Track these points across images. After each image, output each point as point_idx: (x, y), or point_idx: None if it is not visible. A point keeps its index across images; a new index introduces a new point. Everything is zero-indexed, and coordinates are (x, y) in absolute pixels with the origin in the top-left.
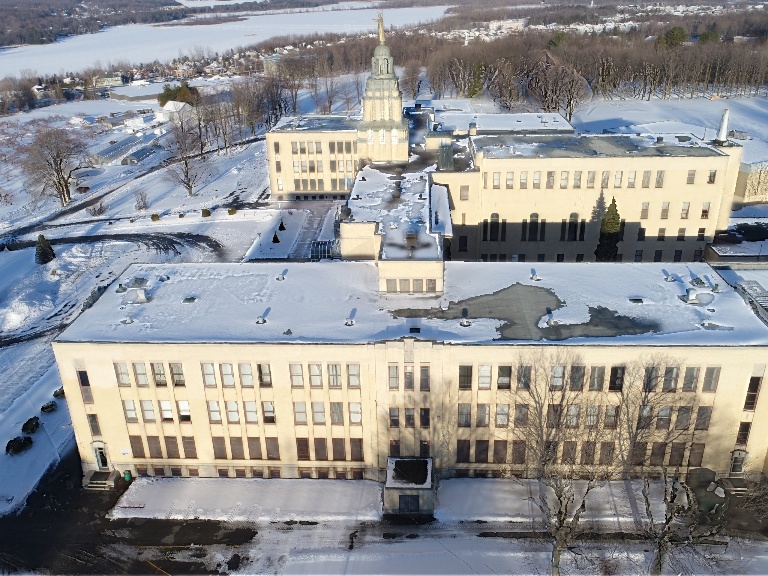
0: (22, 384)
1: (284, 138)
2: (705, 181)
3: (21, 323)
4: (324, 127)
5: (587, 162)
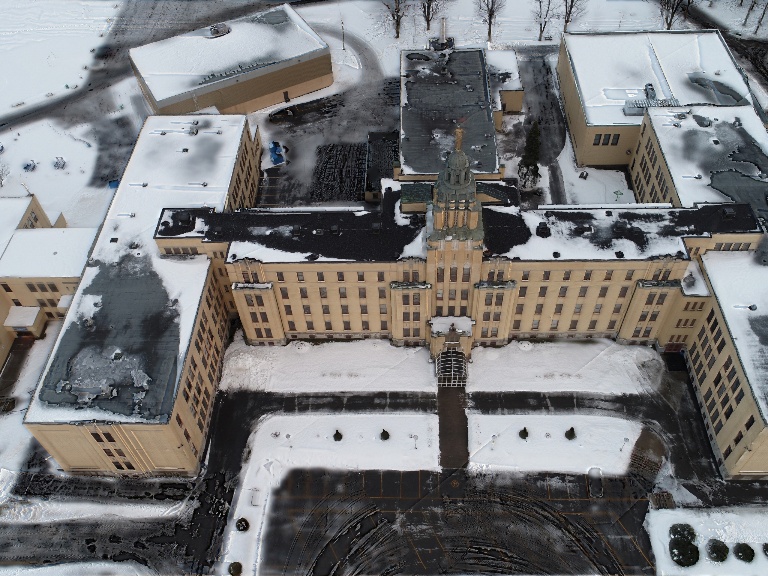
0: None
1: (179, 402)
2: None
3: None
4: (142, 349)
5: None
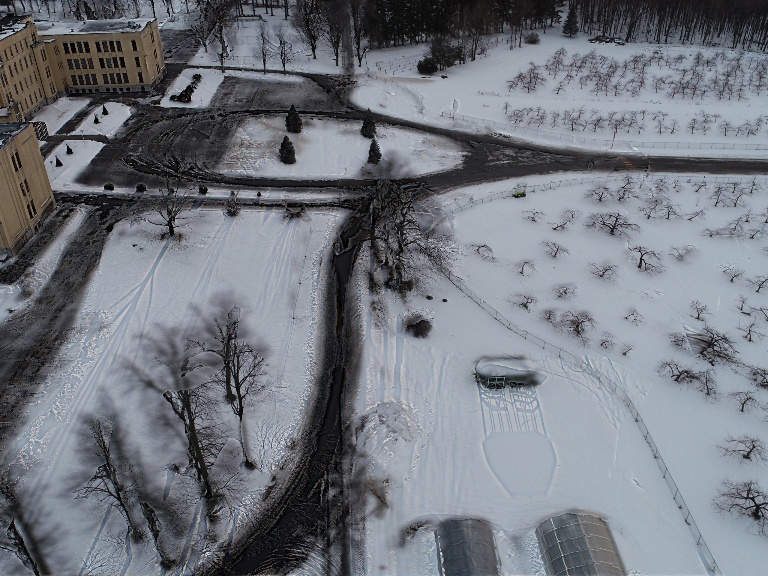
0: (220, 96)
1: None
2: None
3: None
4: None
5: None
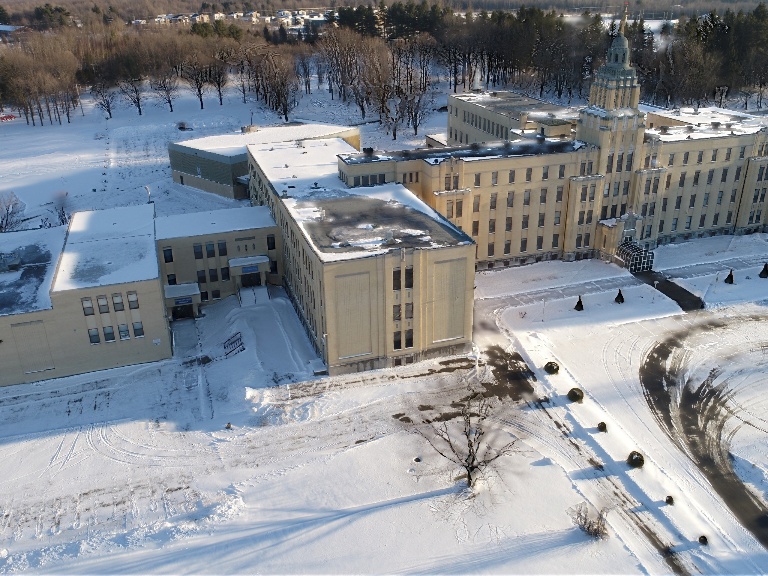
0: None
1: None
2: None
3: None
4: (395, 221)
5: None
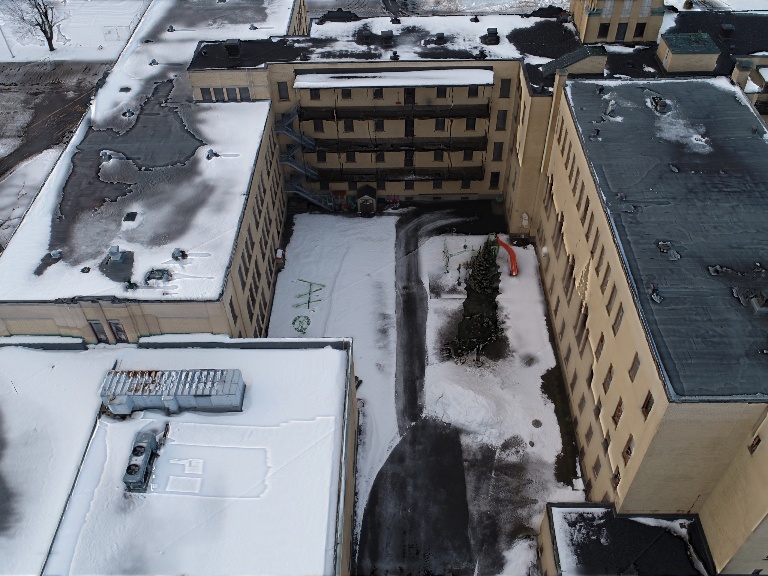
0: None
1: None
2: (641, 399)
3: (427, 7)
4: None
5: (594, 192)
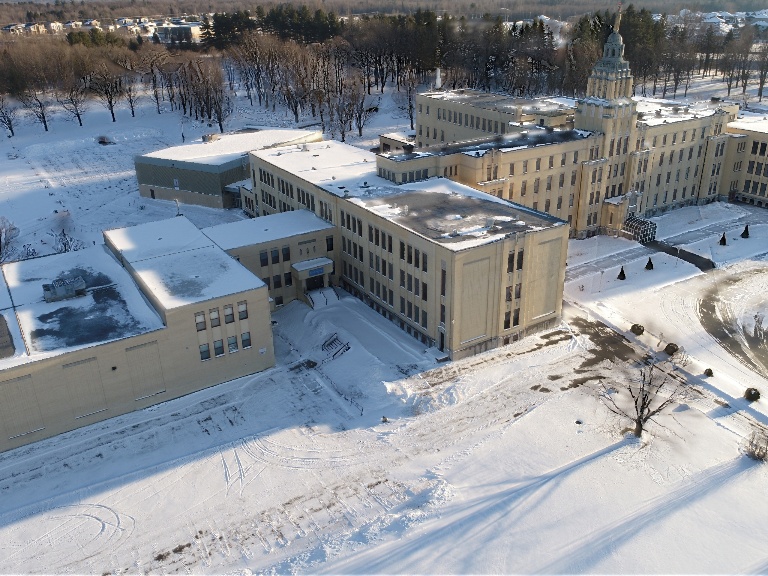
0: None
1: None
2: None
3: None
4: (476, 210)
5: None
